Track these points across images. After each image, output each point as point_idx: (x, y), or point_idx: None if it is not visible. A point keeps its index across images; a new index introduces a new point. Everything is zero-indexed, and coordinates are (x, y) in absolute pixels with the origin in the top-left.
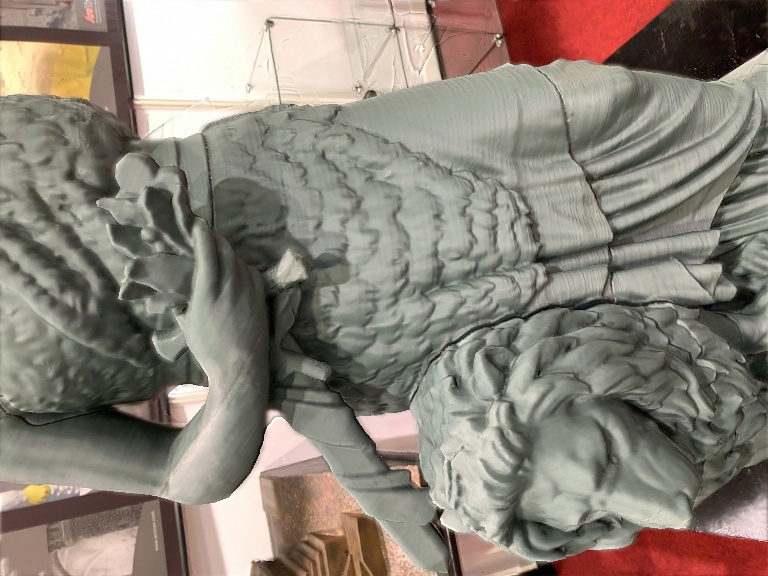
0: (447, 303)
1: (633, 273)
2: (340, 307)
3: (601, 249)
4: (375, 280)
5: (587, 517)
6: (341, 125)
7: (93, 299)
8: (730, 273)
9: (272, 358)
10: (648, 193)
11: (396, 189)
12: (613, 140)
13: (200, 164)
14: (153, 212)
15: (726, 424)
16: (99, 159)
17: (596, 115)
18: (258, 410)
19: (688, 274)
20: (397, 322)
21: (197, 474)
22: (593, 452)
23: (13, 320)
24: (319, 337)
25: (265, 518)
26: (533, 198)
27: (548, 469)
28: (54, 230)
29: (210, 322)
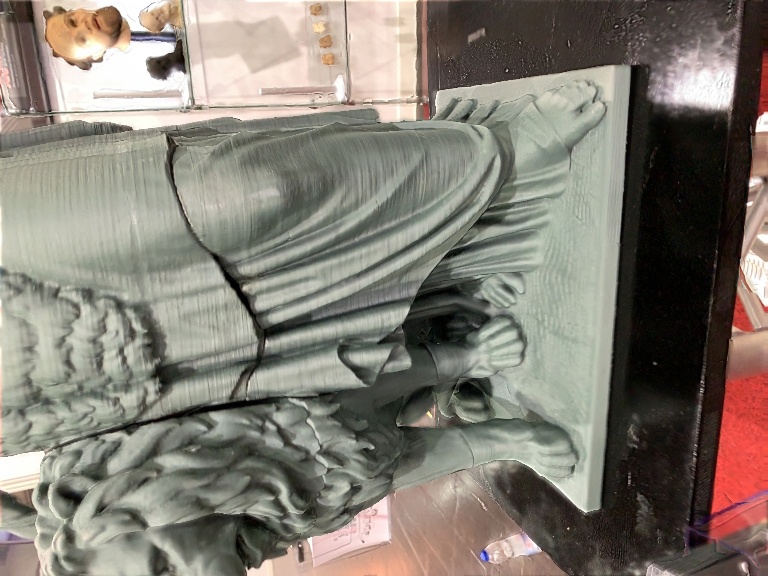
0: (42, 424)
1: (277, 370)
2: None
3: (249, 345)
4: None
5: None
6: None
7: None
8: (471, 295)
9: None
10: (316, 288)
11: None
12: (276, 239)
13: None
14: None
15: (332, 503)
16: None
17: (236, 234)
18: None
19: (343, 366)
20: None
21: None
22: (139, 573)
23: None
24: None
25: None
26: (161, 311)
27: None
28: None
29: None
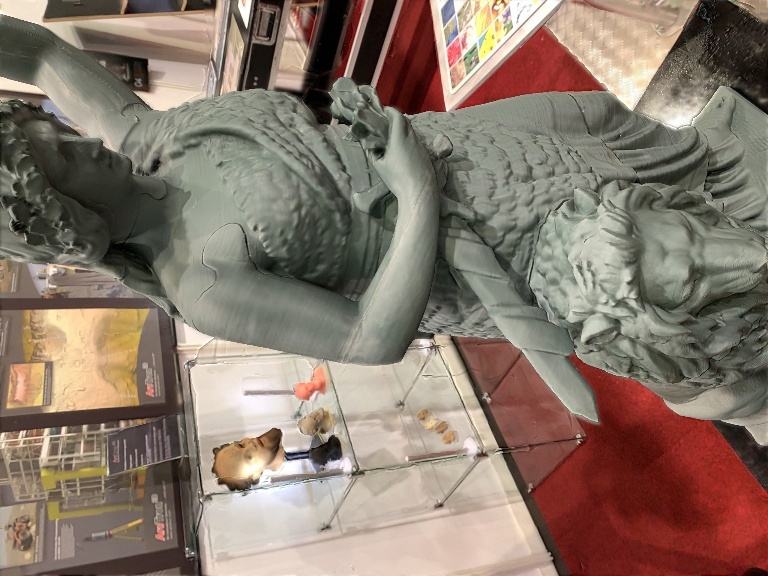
0: (542, 183)
1: None
2: (472, 183)
3: None
4: (491, 169)
5: (695, 296)
6: None
7: (317, 166)
8: None
9: None
10: (650, 161)
11: (488, 134)
12: (614, 132)
13: None
14: None
15: None
16: None
17: (599, 109)
18: (436, 224)
19: None
20: (512, 194)
21: (390, 296)
22: (679, 220)
23: (271, 170)
24: None
25: None
26: None
27: (652, 235)
28: (289, 132)
29: (404, 150)
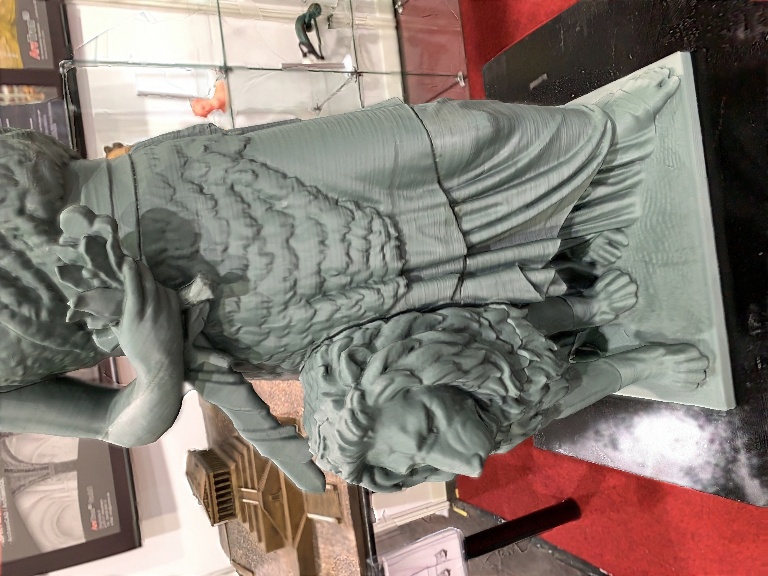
0: (325, 310)
1: (480, 280)
2: (241, 313)
3: (458, 260)
4: (269, 293)
5: (417, 464)
6: (248, 161)
7: (45, 309)
8: (581, 260)
9: (186, 354)
10: (502, 213)
11: (290, 218)
12: (477, 170)
13: (129, 194)
14: (91, 257)
15: (532, 397)
16: (45, 195)
17: (460, 155)
18: (175, 391)
19: (525, 280)
20: (286, 323)
21: (130, 430)
22: (417, 427)
23: None
24: (225, 334)
25: (201, 413)
26: (404, 222)
27: (385, 437)
28: (11, 256)
29: (137, 336)
